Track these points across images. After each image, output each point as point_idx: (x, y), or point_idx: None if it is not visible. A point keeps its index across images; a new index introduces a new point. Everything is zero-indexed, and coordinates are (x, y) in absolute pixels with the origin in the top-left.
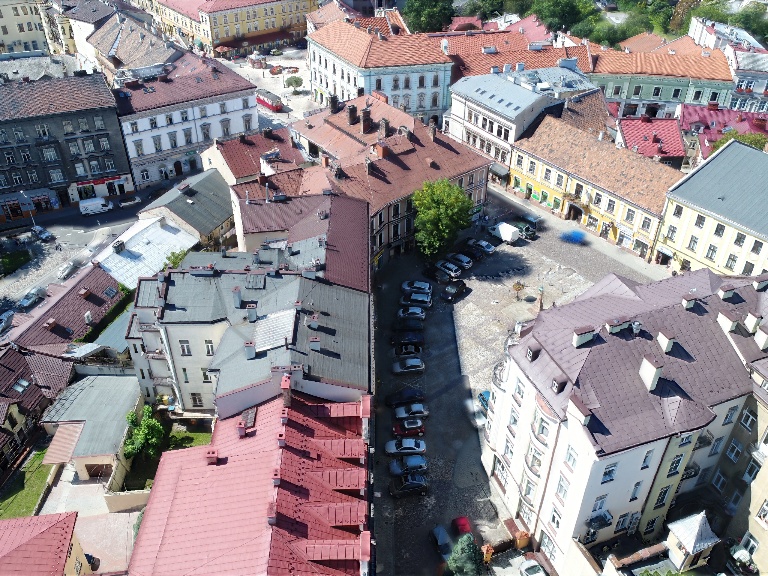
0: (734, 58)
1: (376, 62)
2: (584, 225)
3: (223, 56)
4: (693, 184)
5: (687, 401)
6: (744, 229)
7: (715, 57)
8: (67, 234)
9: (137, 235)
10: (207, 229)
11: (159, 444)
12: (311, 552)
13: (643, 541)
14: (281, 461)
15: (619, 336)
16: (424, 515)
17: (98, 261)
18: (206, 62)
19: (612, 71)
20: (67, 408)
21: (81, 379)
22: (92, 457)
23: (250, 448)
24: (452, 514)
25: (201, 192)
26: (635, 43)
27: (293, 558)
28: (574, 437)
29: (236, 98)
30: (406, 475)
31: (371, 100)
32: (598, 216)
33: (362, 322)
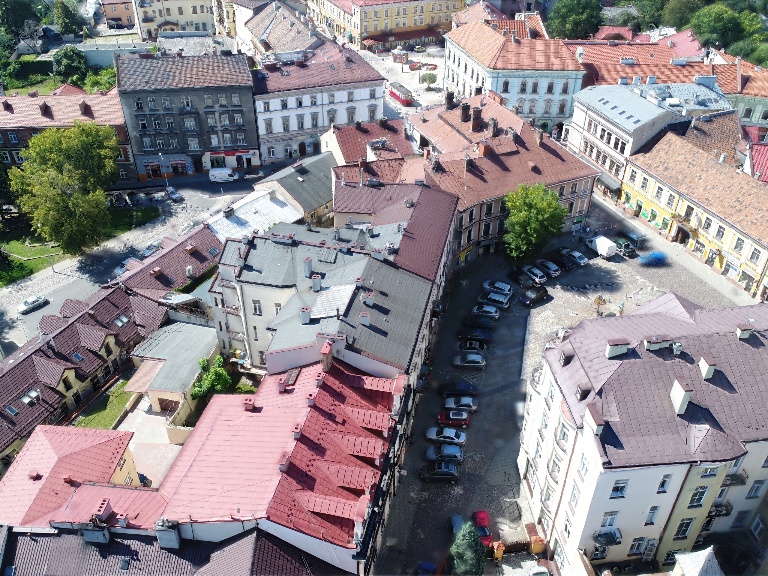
0: None
1: (506, 64)
2: (690, 250)
3: (369, 49)
4: None
5: (716, 431)
6: None
7: None
8: (194, 197)
9: (247, 204)
10: (311, 206)
11: (224, 392)
12: (312, 503)
13: (659, 571)
14: (306, 418)
15: (657, 354)
16: (448, 502)
17: (208, 222)
18: (342, 51)
19: (762, 94)
20: (154, 347)
21: (172, 324)
22: (164, 392)
23: (285, 403)
24: (476, 507)
25: (313, 172)
26: None
27: (294, 505)
28: (587, 446)
29: (364, 88)
30: (440, 462)
31: (486, 100)
32: (706, 242)
33: (418, 307)
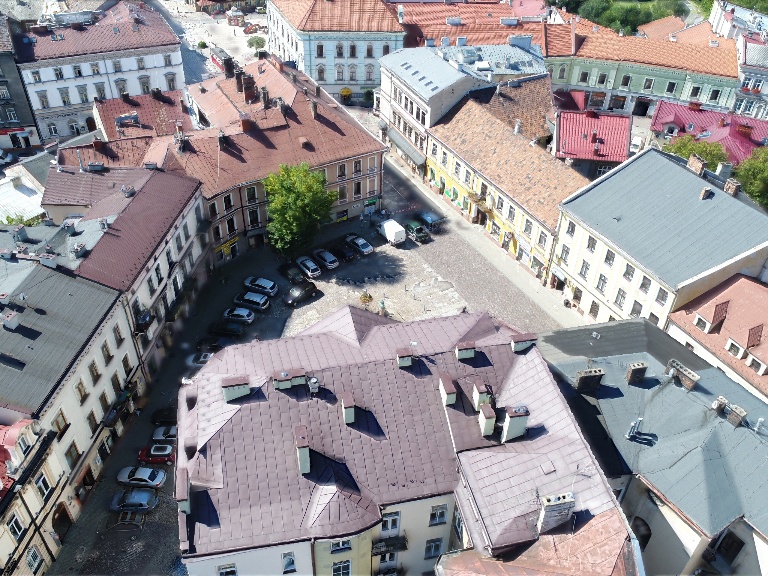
0: (742, 51)
1: (317, 25)
2: (488, 232)
3: (205, 10)
4: (591, 197)
5: (344, 495)
6: (631, 260)
7: (723, 48)
8: None
9: None
10: None
11: None
12: None
13: None
14: None
15: (289, 394)
16: (119, 565)
17: None
18: (131, 12)
19: (597, 56)
20: None
21: None
22: None
23: None
24: (152, 569)
25: None
26: (655, 27)
27: None
28: None
29: (156, 54)
30: (126, 511)
31: (265, 66)
32: (500, 223)
33: (86, 326)
